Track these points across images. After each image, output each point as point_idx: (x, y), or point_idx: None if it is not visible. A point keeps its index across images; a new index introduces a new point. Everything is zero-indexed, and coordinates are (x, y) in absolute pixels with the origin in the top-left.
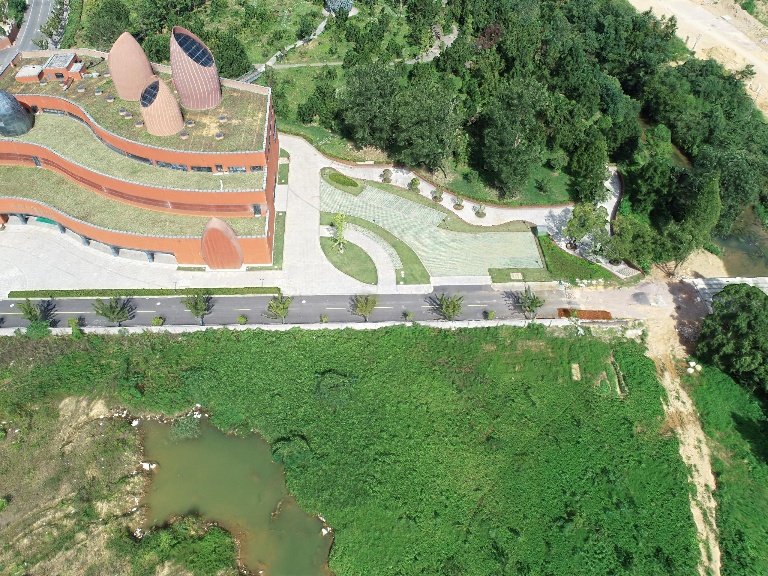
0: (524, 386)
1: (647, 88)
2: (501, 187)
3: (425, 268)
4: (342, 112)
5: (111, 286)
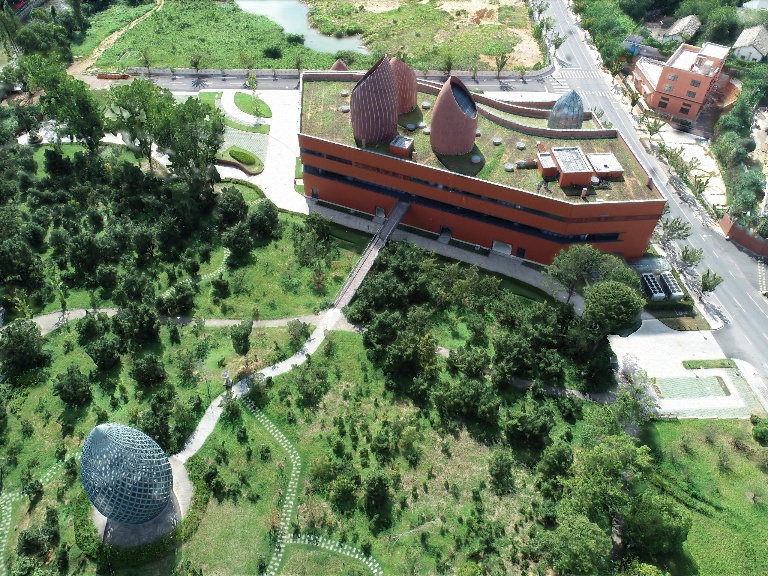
0: None
1: None
2: None
3: None
4: None
5: None
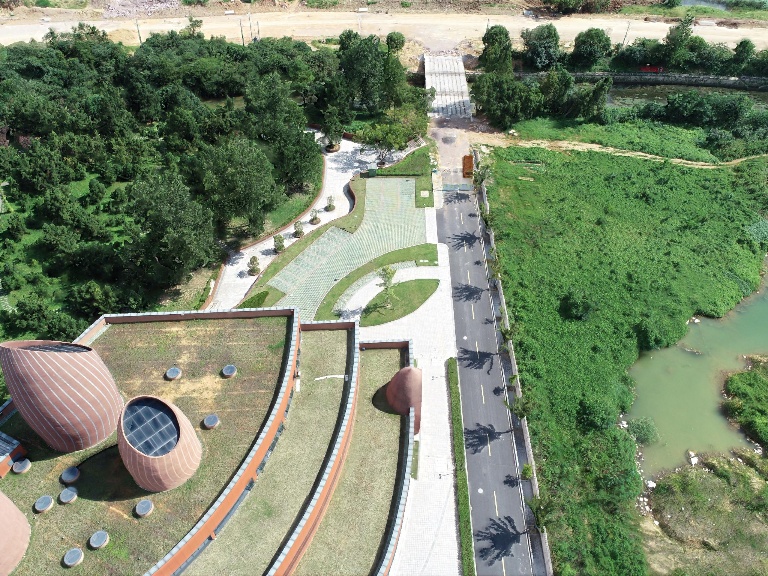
0: (548, 201)
1: (171, 77)
2: (290, 189)
3: (415, 246)
4: None
5: (452, 568)
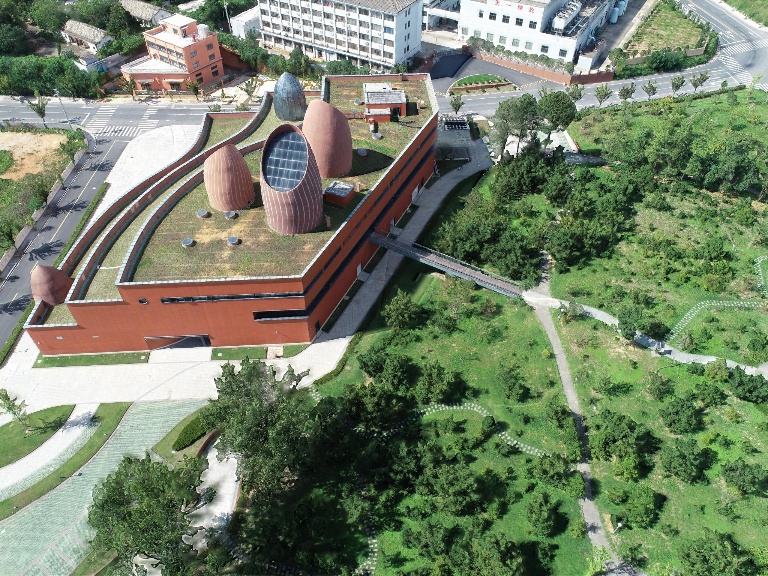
0: None
1: None
2: None
3: None
4: (362, 410)
5: None
